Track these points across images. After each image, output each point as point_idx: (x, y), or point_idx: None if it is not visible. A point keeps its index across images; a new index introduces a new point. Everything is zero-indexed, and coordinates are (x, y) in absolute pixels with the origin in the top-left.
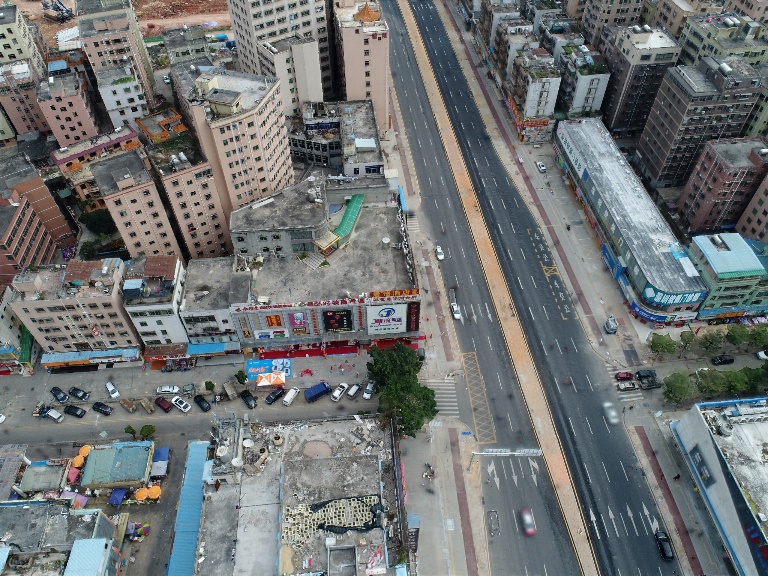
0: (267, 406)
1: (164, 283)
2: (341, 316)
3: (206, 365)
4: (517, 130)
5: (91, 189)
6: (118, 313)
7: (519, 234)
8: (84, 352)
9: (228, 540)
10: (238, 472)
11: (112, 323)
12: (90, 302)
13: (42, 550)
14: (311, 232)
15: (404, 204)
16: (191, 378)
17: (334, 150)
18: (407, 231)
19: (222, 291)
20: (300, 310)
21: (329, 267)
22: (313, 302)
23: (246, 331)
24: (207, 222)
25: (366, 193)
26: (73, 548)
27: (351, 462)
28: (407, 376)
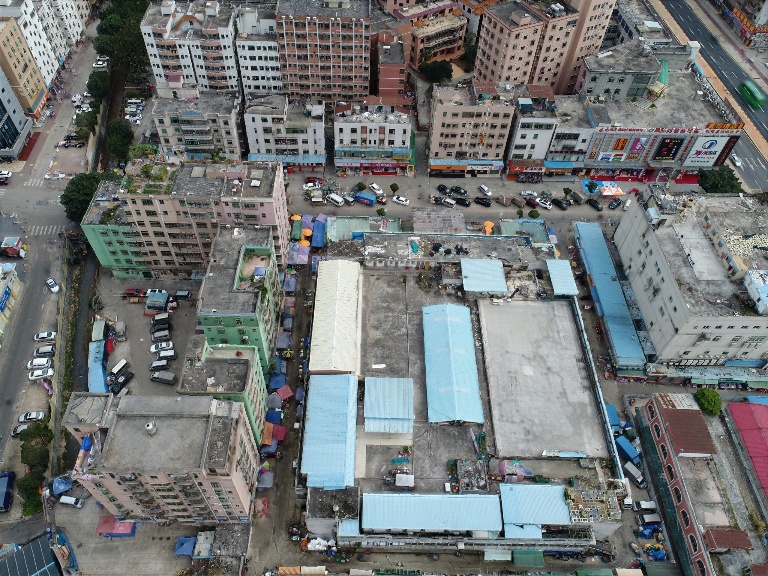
0: (610, 210)
1: (548, 103)
2: (674, 144)
3: (551, 181)
4: (745, 36)
5: (425, 44)
6: (509, 124)
7: (767, 113)
8: (462, 160)
9: (681, 256)
10: (678, 214)
11: (498, 134)
12: (496, 111)
13: (523, 264)
14: (650, 78)
15: (701, 70)
16: (542, 188)
17: (610, 34)
18: (711, 89)
19: (581, 117)
20: (646, 135)
21: (657, 109)
22: (660, 128)
23: (594, 152)
24: (552, 69)
25: (670, 59)
26: (548, 263)
27: (757, 215)
28: (737, 188)
